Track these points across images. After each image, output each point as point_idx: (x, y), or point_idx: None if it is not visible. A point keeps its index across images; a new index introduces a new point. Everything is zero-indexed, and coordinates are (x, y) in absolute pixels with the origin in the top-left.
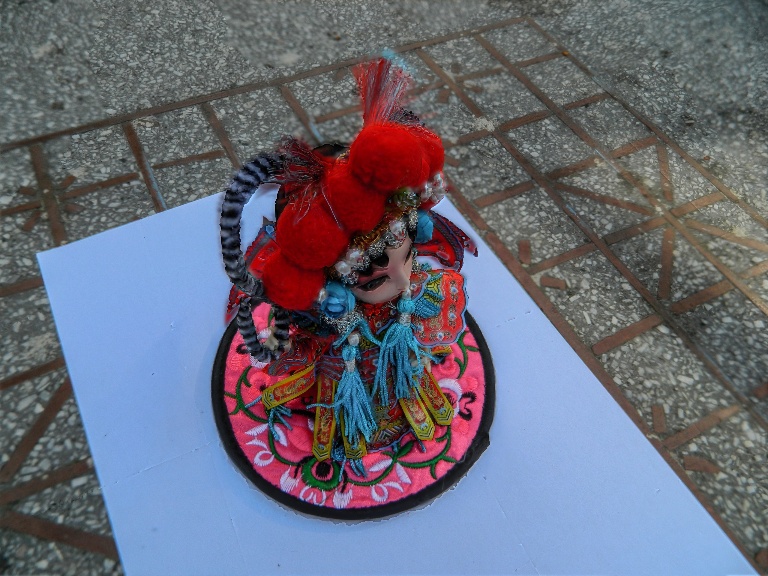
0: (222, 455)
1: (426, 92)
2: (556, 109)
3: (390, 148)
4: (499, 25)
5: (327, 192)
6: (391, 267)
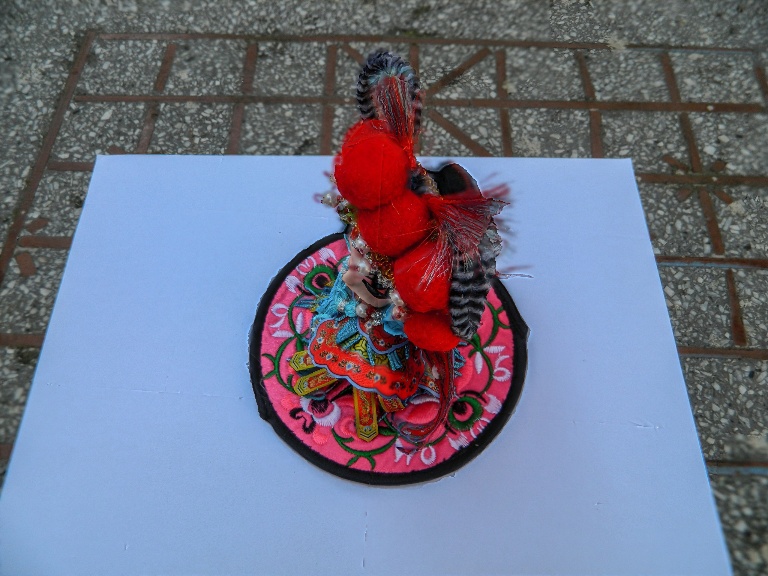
0: None
1: None
2: None
3: (360, 150)
4: None
5: None
6: (350, 247)
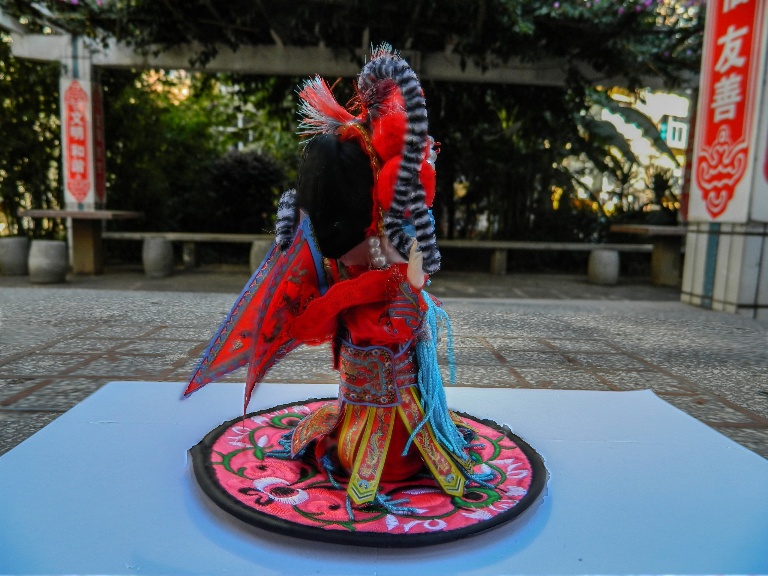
0: (403, 565)
1: (92, 362)
2: (209, 340)
3: None
4: (86, 331)
5: (401, 102)
6: None
